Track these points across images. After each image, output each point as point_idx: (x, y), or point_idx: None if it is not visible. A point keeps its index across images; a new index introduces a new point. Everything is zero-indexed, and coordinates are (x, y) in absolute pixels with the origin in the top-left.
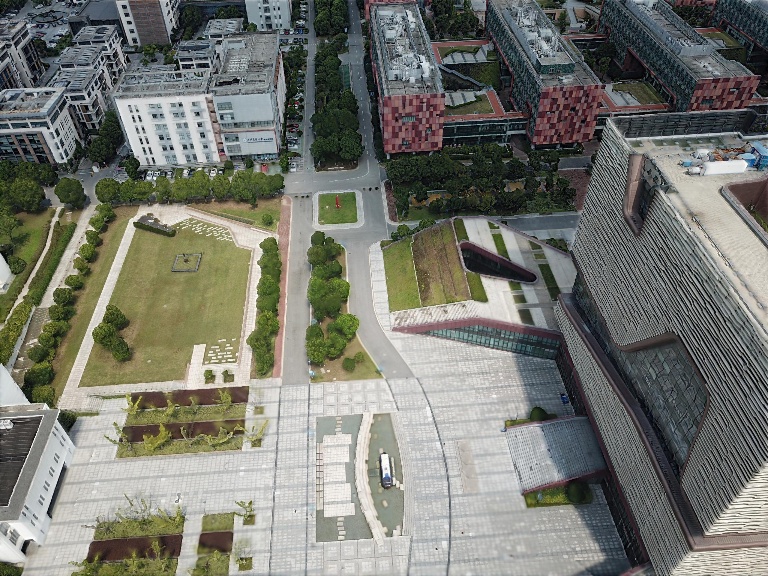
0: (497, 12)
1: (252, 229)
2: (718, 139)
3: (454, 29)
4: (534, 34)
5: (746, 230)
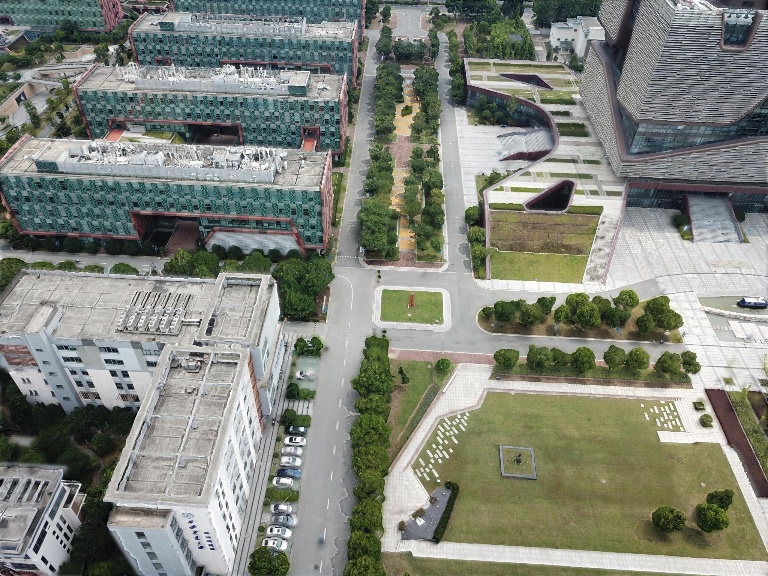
0: (123, 91)
1: (445, 391)
2: None
3: None
4: (236, 75)
5: None
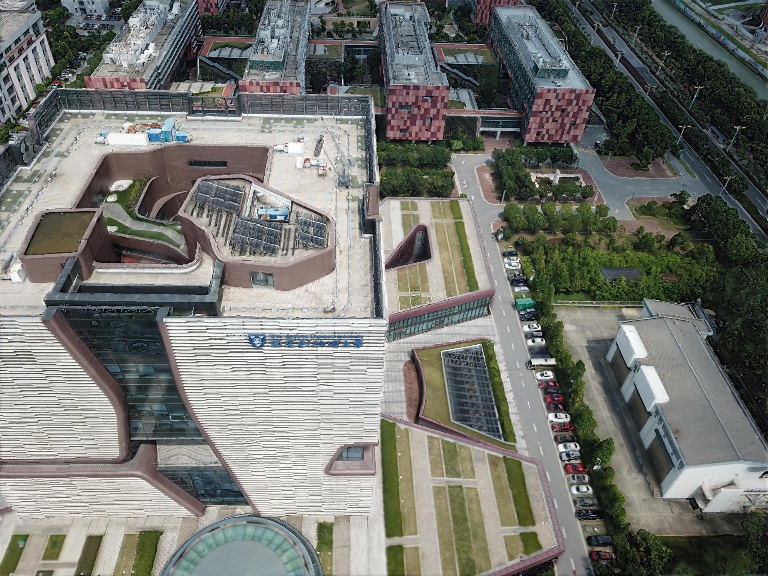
0: None
1: None
2: (168, 117)
3: (249, 27)
4: (265, 32)
5: (80, 190)
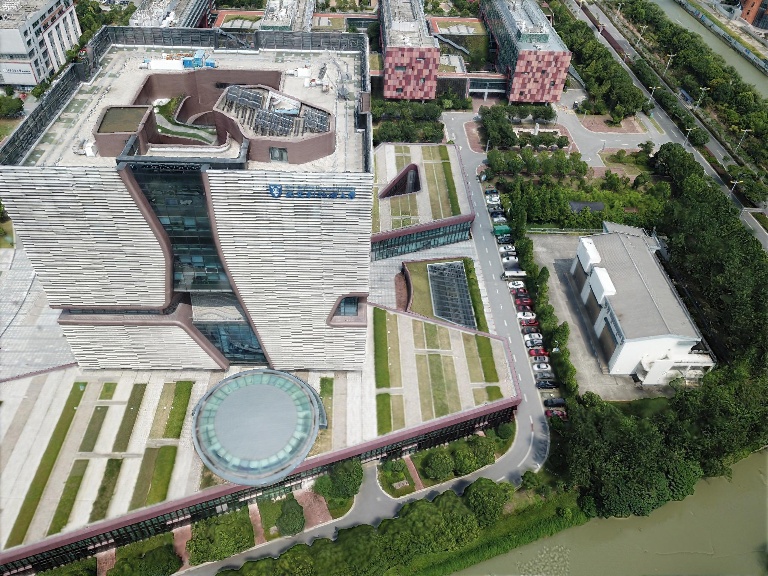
0: None
1: None
2: None
3: (258, 3)
4: (275, 2)
5: (131, 99)
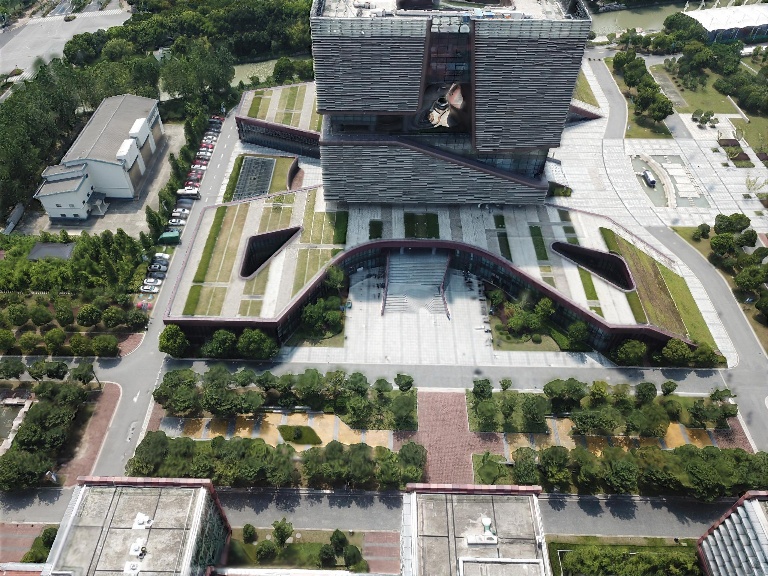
0: None
1: None
2: None
3: None
4: None
5: None
